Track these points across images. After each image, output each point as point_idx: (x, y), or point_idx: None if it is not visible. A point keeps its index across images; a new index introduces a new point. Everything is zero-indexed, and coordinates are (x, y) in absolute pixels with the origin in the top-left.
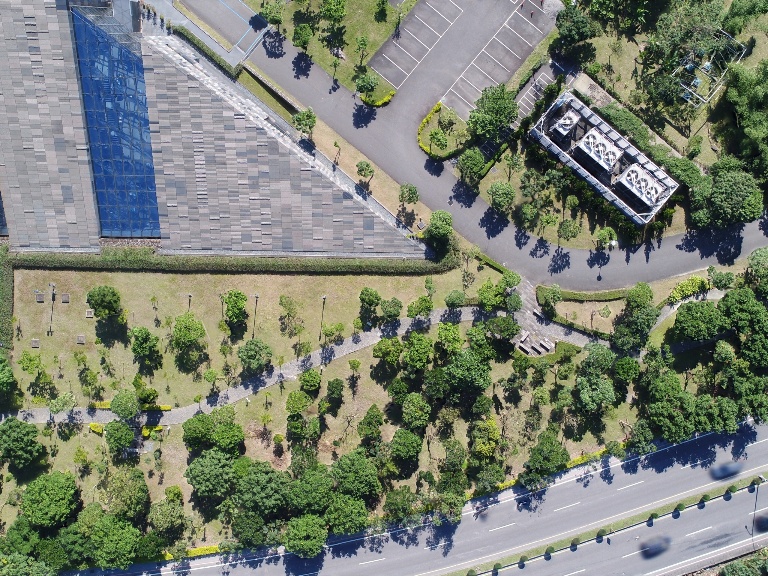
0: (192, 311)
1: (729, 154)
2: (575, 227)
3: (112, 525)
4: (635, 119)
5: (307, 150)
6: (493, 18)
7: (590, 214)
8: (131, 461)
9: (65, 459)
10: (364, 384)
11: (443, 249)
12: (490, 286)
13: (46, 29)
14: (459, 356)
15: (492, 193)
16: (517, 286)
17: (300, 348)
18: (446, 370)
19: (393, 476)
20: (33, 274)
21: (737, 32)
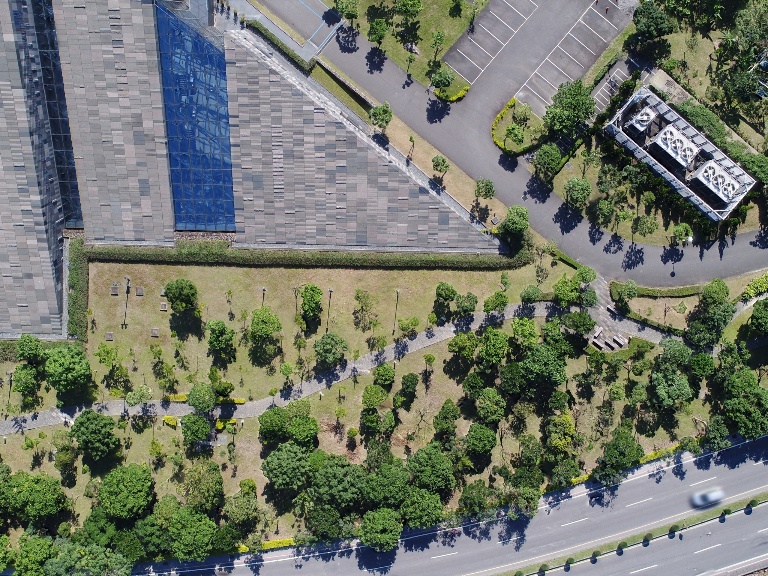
0: (266, 305)
1: None
2: (652, 223)
3: (190, 517)
4: (712, 115)
5: (380, 145)
6: (568, 14)
7: (664, 210)
8: (204, 454)
9: (139, 451)
10: (437, 379)
11: (517, 244)
12: (566, 281)
13: (130, 22)
14: (536, 351)
15: (569, 189)
16: (591, 282)
17: (373, 342)
18: (522, 365)
19: (466, 470)
20: (108, 267)
21: None
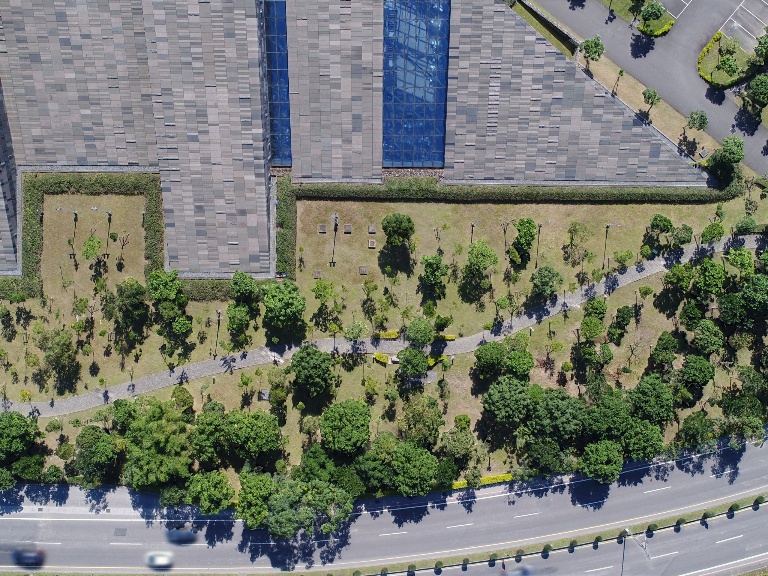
0: (475, 241)
1: None
2: None
3: (414, 451)
4: None
5: None
6: None
7: None
8: (415, 391)
9: (349, 389)
10: (647, 313)
11: (728, 177)
12: None
13: None
14: (757, 280)
15: None
16: None
17: (583, 277)
18: (739, 296)
19: (677, 404)
20: (315, 205)
21: None
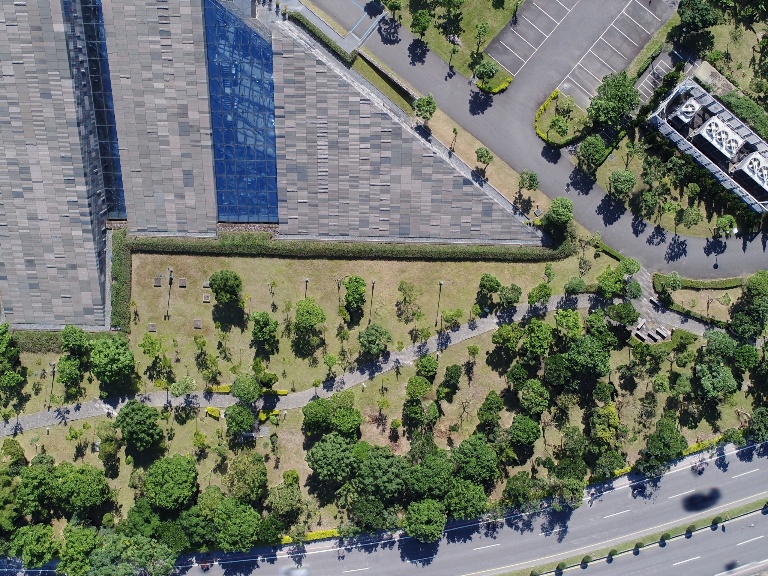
0: (309, 296)
1: None
2: (697, 215)
3: (235, 508)
4: (756, 107)
5: (423, 137)
6: (611, 5)
7: (707, 202)
8: (247, 445)
9: (181, 443)
10: (480, 370)
11: (561, 236)
12: (610, 273)
13: (178, 13)
14: (581, 342)
15: (614, 180)
16: (634, 274)
17: (416, 334)
18: (566, 356)
19: (508, 462)
20: (150, 258)
21: None
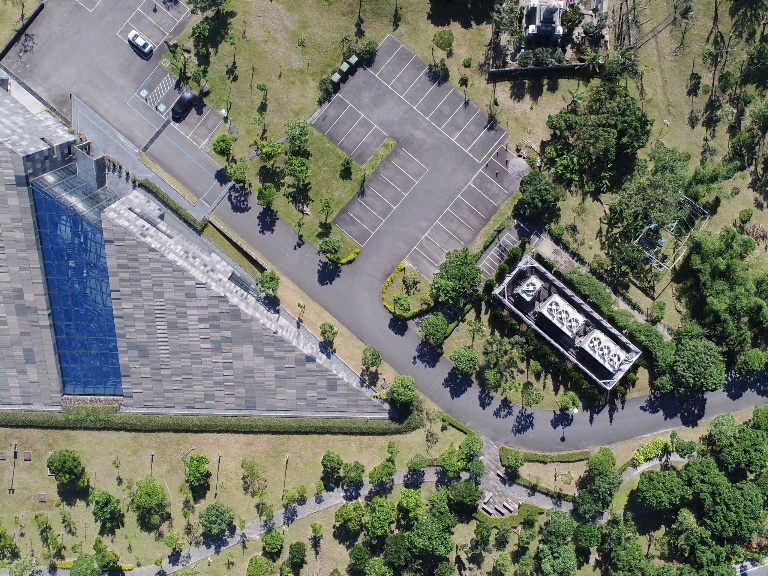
0: (154, 470)
1: (692, 319)
2: (537, 395)
3: None
4: (598, 285)
5: (271, 306)
6: (458, 177)
7: (554, 375)
8: None
9: None
10: (327, 544)
11: (406, 410)
12: (452, 451)
13: (6, 204)
14: (420, 525)
15: (455, 359)
16: None
17: (263, 508)
18: (408, 536)
19: None
20: None
21: (701, 197)
